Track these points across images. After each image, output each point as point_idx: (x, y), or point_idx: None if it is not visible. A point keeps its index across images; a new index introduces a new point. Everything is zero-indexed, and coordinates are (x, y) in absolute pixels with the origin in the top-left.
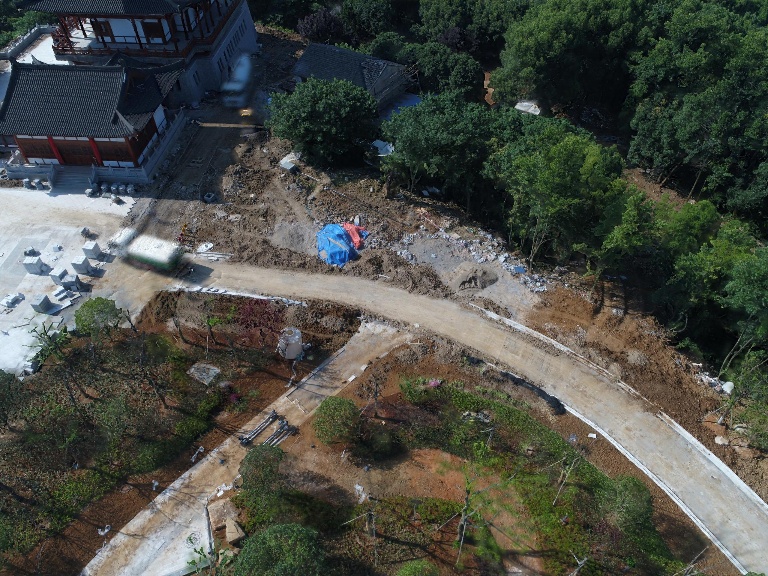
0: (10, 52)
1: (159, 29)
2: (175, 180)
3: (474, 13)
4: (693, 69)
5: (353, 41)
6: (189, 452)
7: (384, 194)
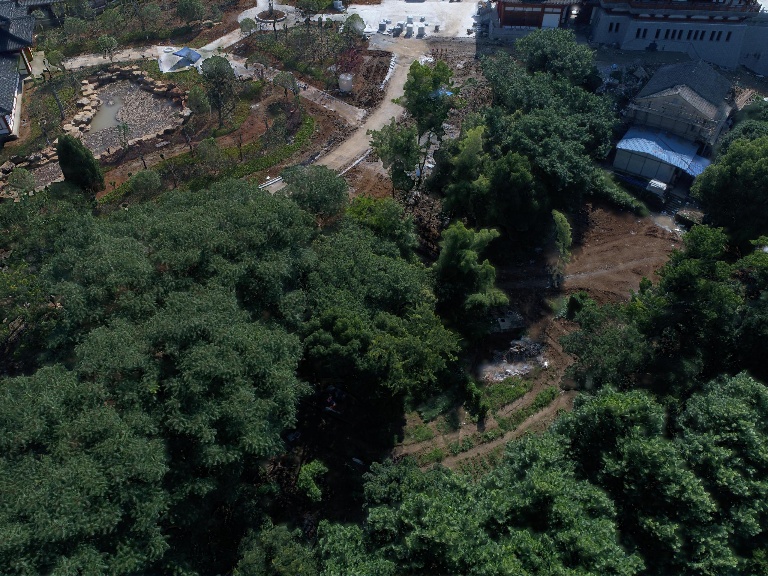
0: None
1: None
2: (497, 46)
3: None
4: (761, 274)
5: None
6: (291, 70)
7: None
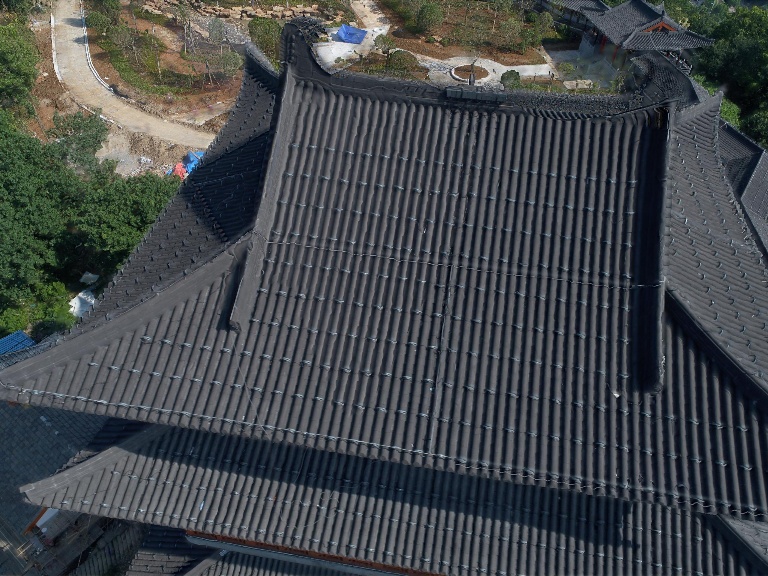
0: None
1: None
2: None
3: None
4: None
5: None
6: None
7: None
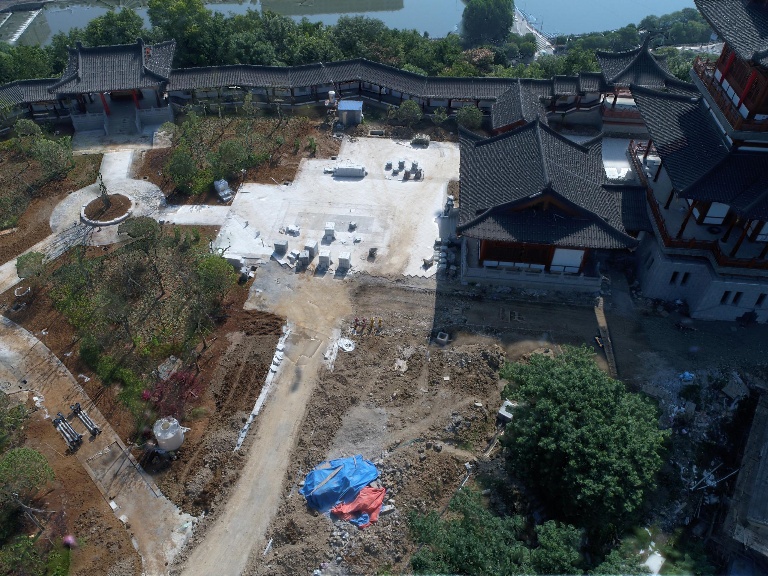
0: None
1: (705, 204)
2: (473, 302)
3: None
4: None
5: None
6: (88, 371)
7: None
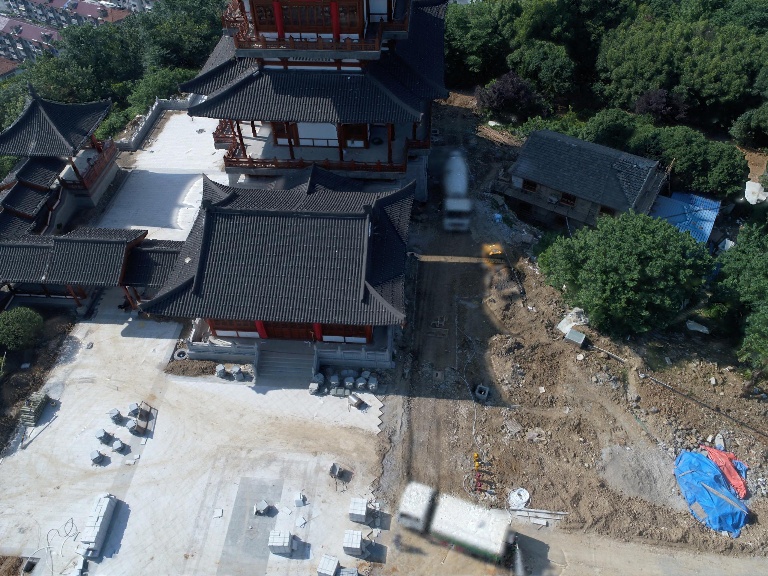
0: (133, 140)
1: (363, 130)
2: (422, 360)
3: (683, 72)
4: None
5: (544, 112)
6: None
7: (737, 391)
